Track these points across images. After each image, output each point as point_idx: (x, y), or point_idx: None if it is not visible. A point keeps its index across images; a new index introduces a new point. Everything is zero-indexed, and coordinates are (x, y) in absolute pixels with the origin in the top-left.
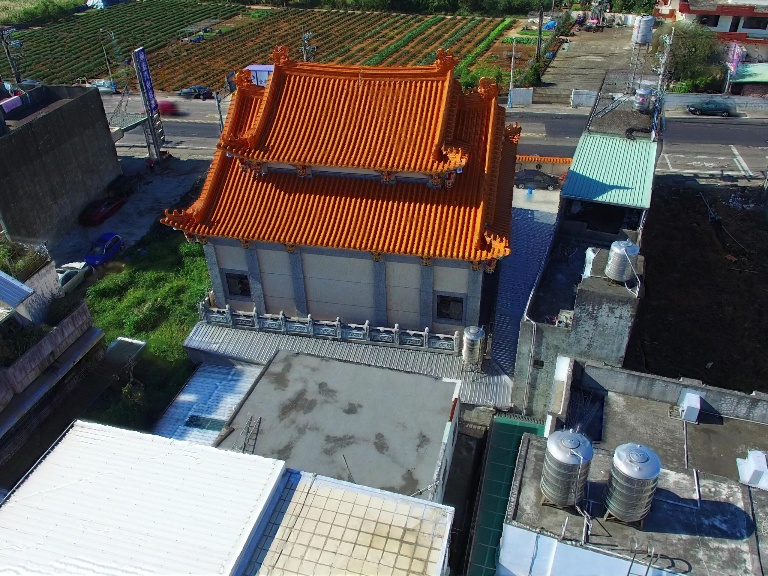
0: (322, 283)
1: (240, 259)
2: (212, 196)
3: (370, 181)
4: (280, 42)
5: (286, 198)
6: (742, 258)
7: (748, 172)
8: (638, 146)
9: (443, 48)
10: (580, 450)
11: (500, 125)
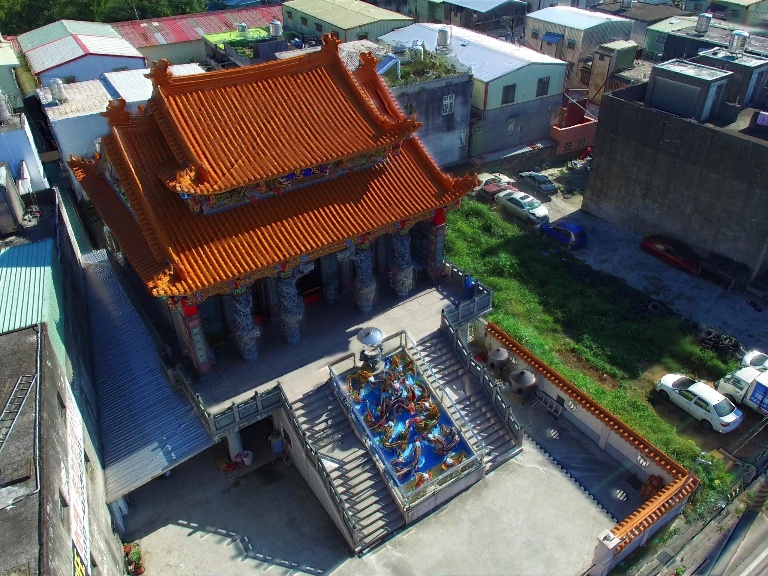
0: None
1: None
2: None
3: None
4: None
5: None
6: None
7: None
8: None
9: None
10: None
11: None
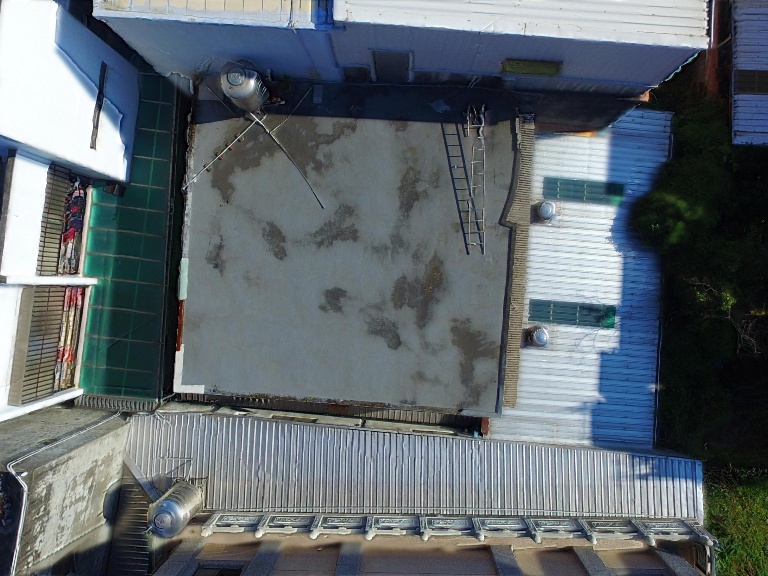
0: None
1: None
2: None
3: None
4: None
5: None
6: None
7: None
8: None
9: None
10: None
11: None
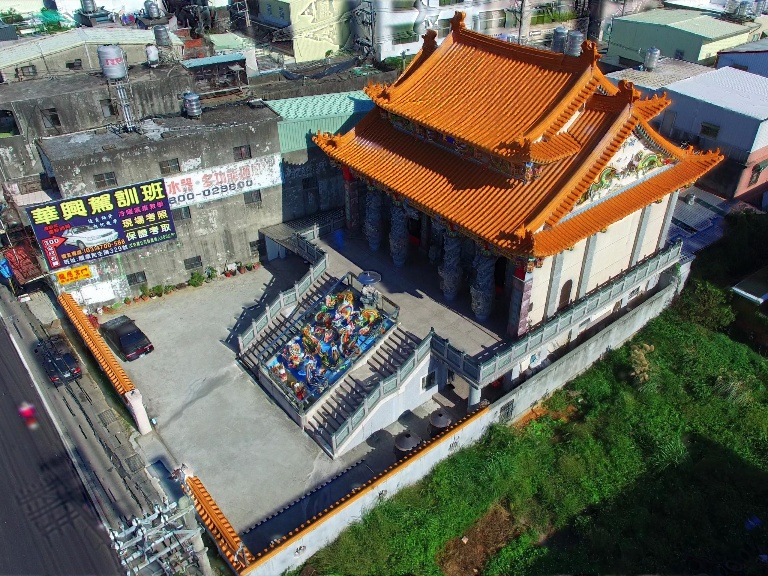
0: None
1: None
2: None
3: None
4: None
5: None
6: None
7: None
8: (279, 104)
9: None
10: None
11: None
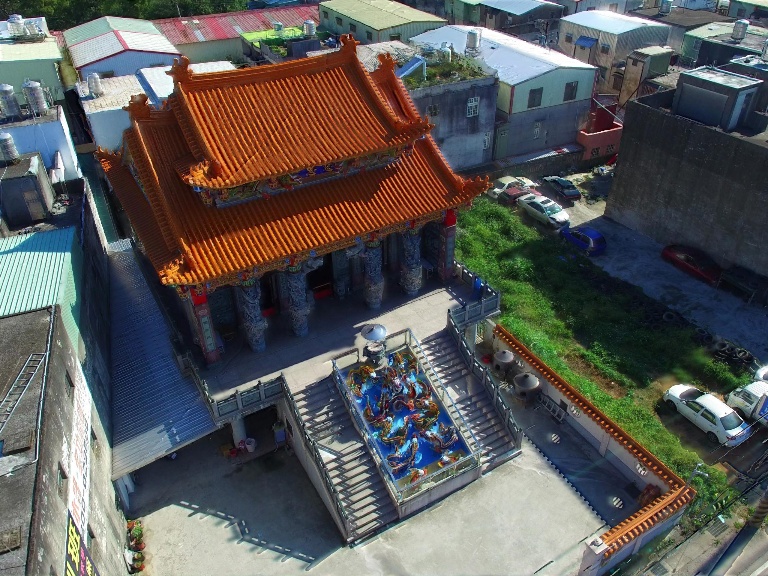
0: None
1: None
2: None
3: None
4: None
5: None
6: None
7: None
8: None
9: None
10: None
11: None
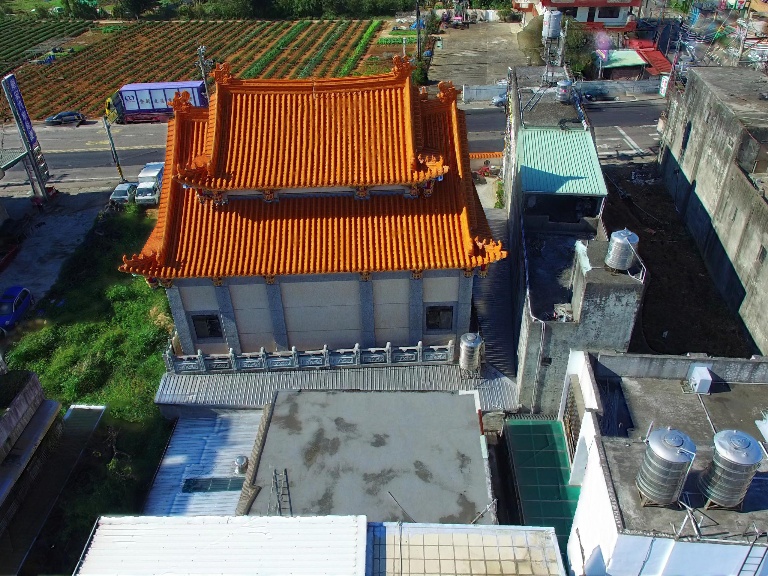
0: (303, 311)
1: (209, 298)
2: (170, 234)
3: (343, 198)
4: (145, 57)
5: (255, 226)
6: (659, 230)
7: (639, 150)
8: (574, 136)
9: (321, 53)
10: (686, 447)
11: (463, 128)
